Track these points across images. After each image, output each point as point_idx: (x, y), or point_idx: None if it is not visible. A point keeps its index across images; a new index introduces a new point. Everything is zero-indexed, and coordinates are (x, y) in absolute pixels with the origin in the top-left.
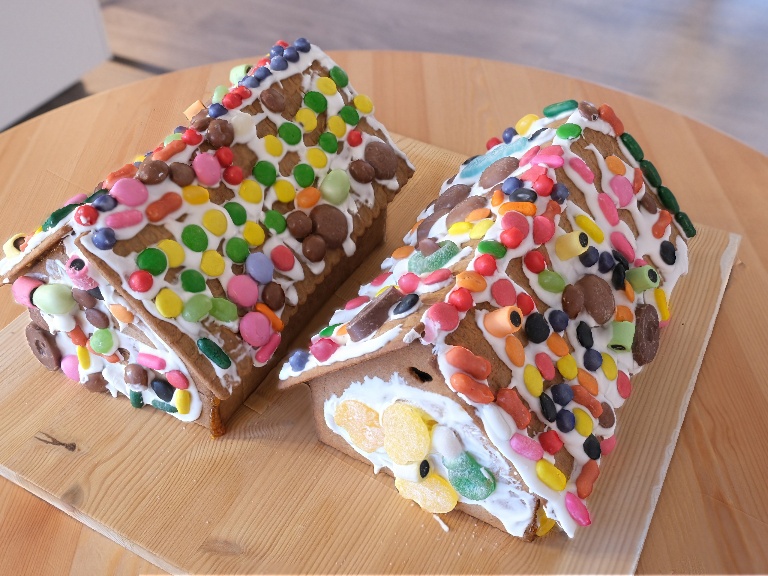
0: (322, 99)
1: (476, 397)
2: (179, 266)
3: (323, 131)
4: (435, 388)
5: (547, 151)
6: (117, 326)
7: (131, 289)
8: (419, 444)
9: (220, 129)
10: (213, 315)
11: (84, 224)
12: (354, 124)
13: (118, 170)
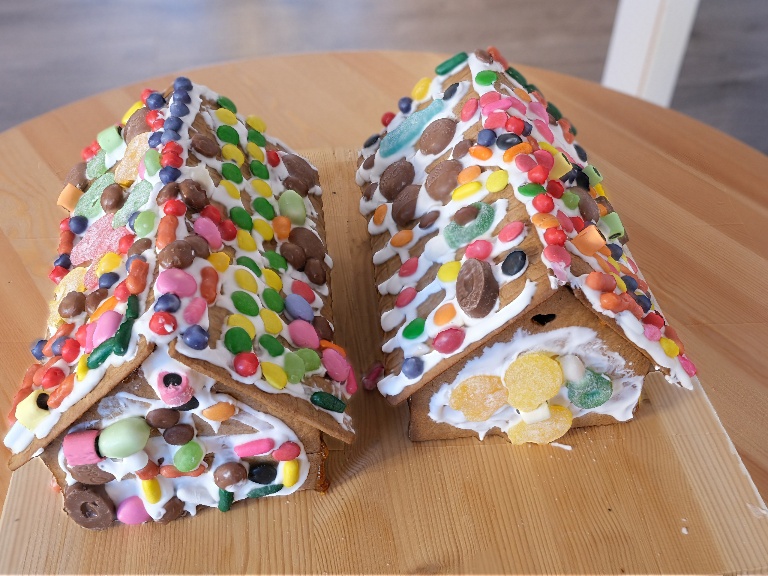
0: (233, 130)
1: (621, 307)
2: (254, 336)
3: (247, 162)
4: (560, 324)
5: (488, 99)
6: (200, 433)
7: (242, 377)
8: (555, 381)
9: (196, 189)
10: None
11: (169, 333)
12: (264, 145)
13: (132, 270)
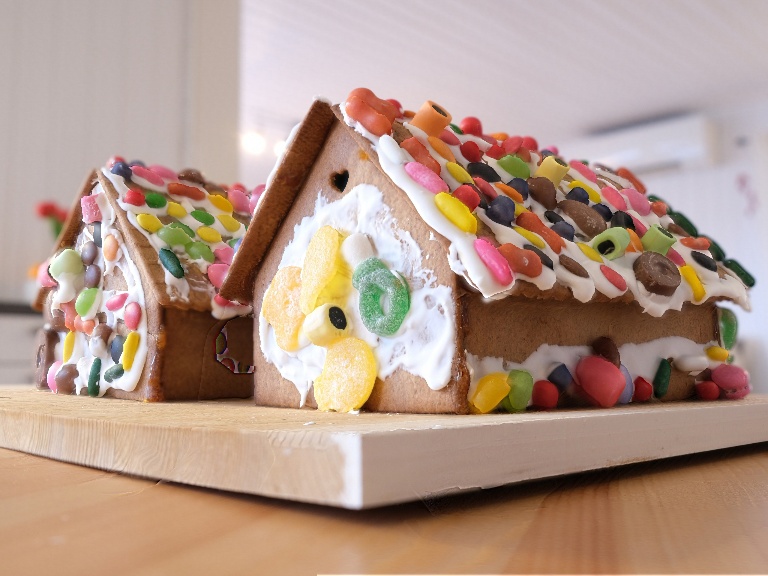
0: None
1: (369, 117)
2: (177, 219)
3: None
4: (350, 183)
5: None
6: (106, 286)
7: (123, 202)
8: (326, 252)
9: None
10: (188, 253)
11: (112, 166)
12: None
13: None
